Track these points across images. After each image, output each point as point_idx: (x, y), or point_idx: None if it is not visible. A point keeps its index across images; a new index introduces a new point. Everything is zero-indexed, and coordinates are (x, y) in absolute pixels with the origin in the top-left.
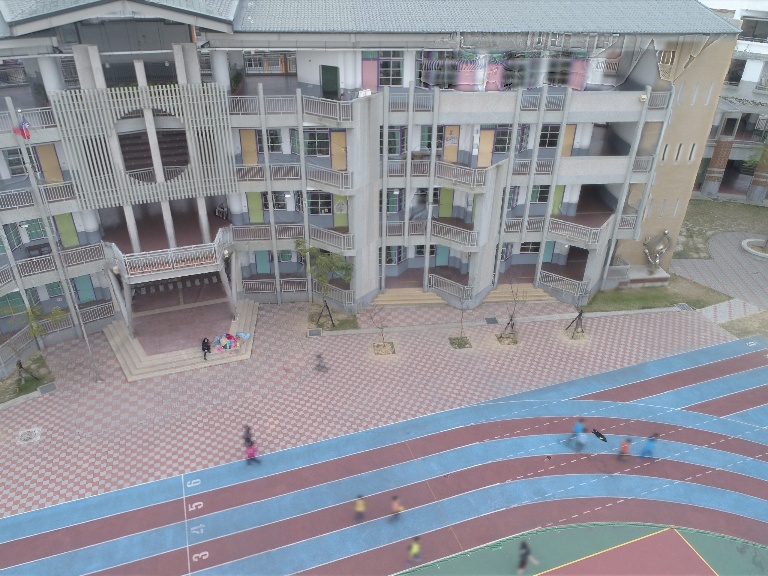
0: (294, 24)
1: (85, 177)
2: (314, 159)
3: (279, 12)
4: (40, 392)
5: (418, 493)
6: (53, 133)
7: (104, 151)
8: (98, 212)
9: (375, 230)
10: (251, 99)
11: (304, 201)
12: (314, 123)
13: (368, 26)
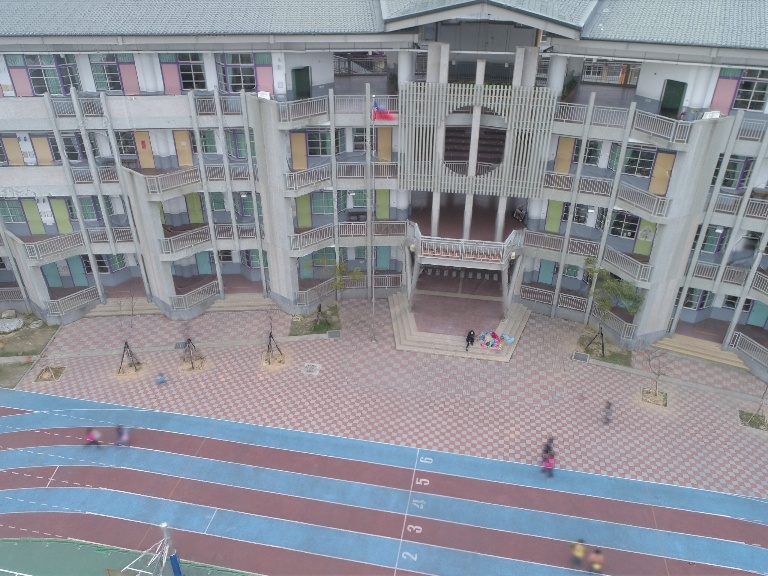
0: (648, 34)
1: (409, 160)
2: (631, 178)
3: (635, 20)
4: (328, 335)
5: (651, 567)
6: (394, 118)
7: (430, 140)
8: (411, 193)
9: (681, 267)
10: (580, 107)
11: (607, 220)
12: (641, 140)
13: (737, 40)
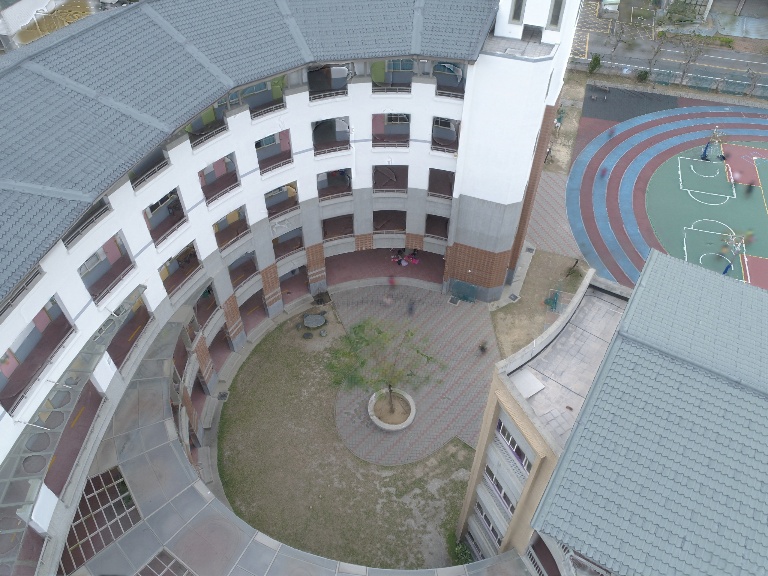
0: None
1: None
2: None
3: None
4: None
5: None
6: None
7: None
8: None
9: None
10: None
11: None
12: None
13: None
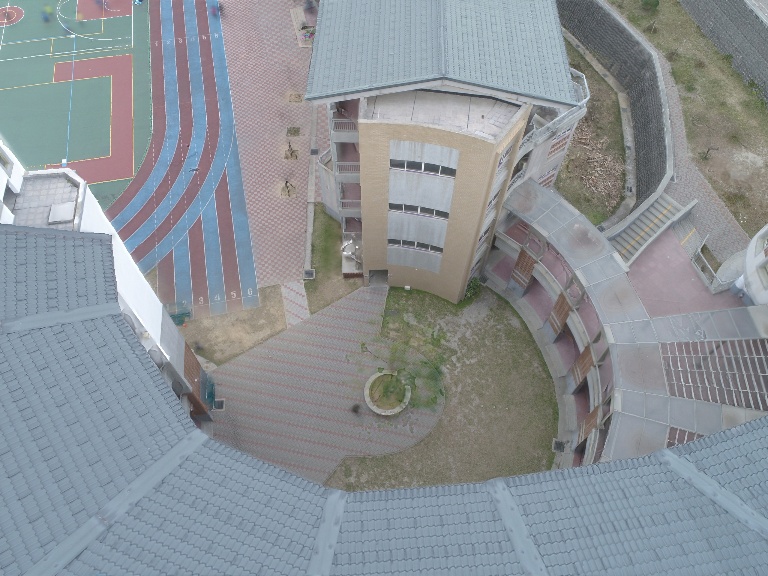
0: None
1: None
2: None
3: None
4: None
5: (186, 99)
6: None
7: None
8: None
9: None
10: None
11: None
12: None
13: None
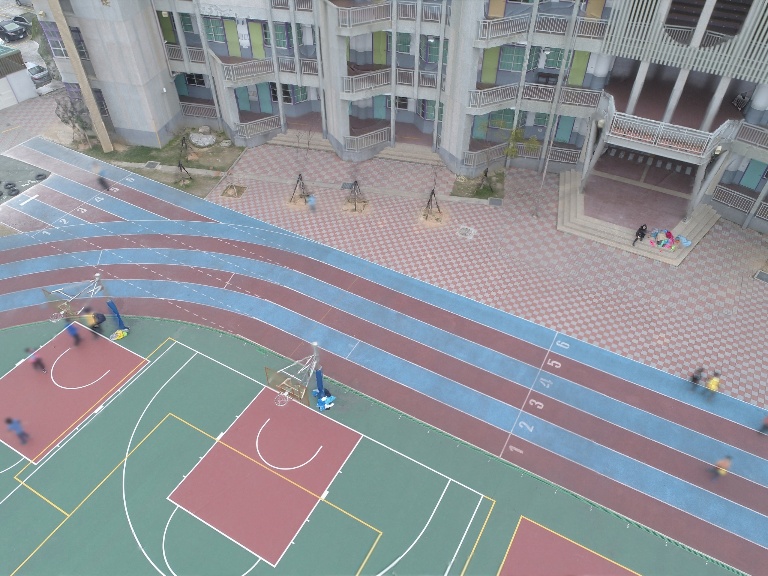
0: None
1: (622, 20)
2: None
3: None
4: (489, 202)
5: None
6: None
7: None
8: (615, 59)
9: None
10: None
11: None
12: None
13: None
